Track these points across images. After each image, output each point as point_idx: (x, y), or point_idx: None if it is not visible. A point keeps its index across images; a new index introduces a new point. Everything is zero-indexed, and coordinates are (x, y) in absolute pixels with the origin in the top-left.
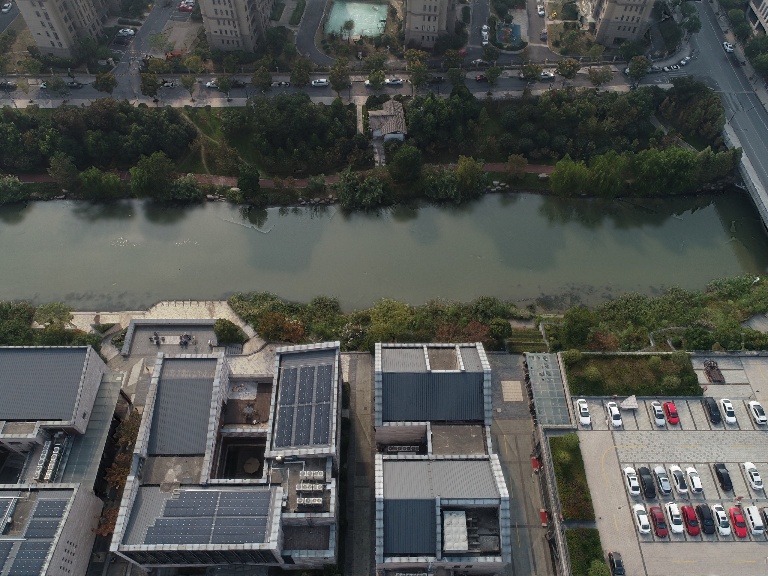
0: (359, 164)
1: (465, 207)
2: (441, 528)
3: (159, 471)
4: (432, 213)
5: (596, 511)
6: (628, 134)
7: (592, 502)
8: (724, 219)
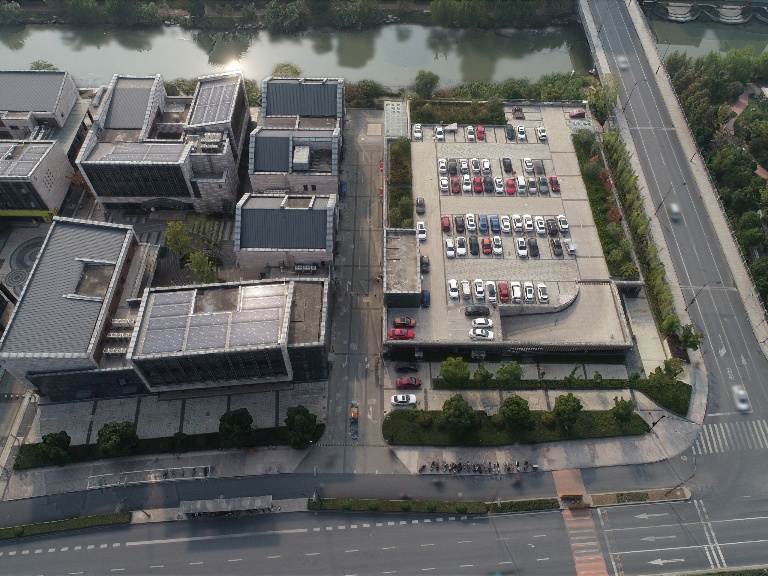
0: (284, 2)
1: (364, 32)
2: (292, 154)
3: (111, 136)
4: (338, 36)
5: (414, 180)
6: None
7: None
8: (570, 50)
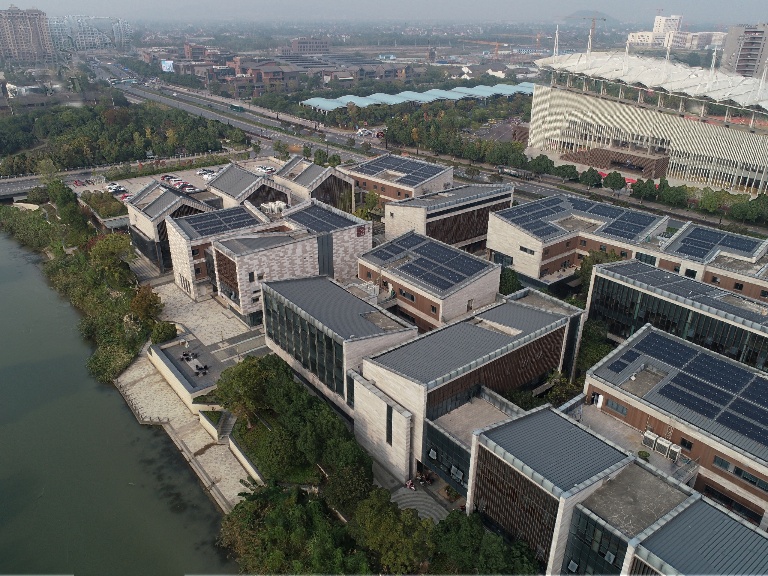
0: None
1: None
2: None
3: None
4: None
5: None
6: None
7: None
8: None
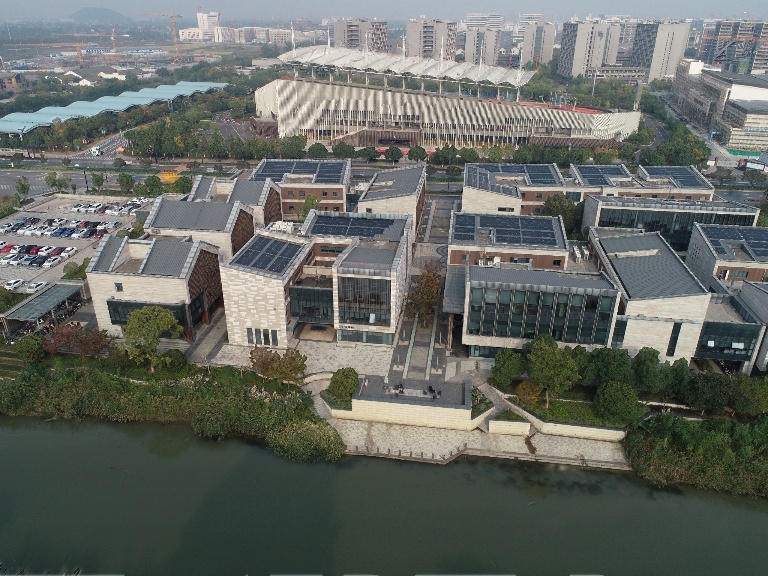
0: None
1: None
2: None
3: (391, 245)
4: None
5: None
6: None
7: None
8: None
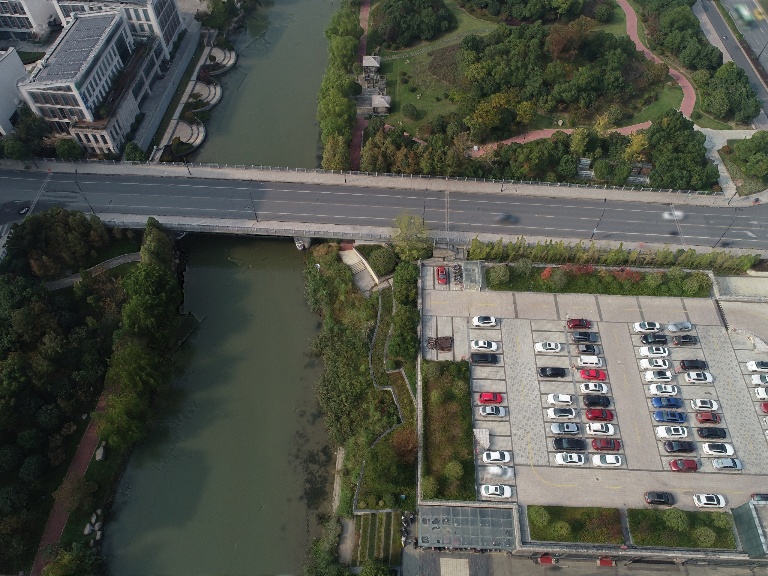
0: None
1: None
2: None
3: None
4: None
5: (605, 505)
6: (69, 324)
7: None
8: (209, 264)
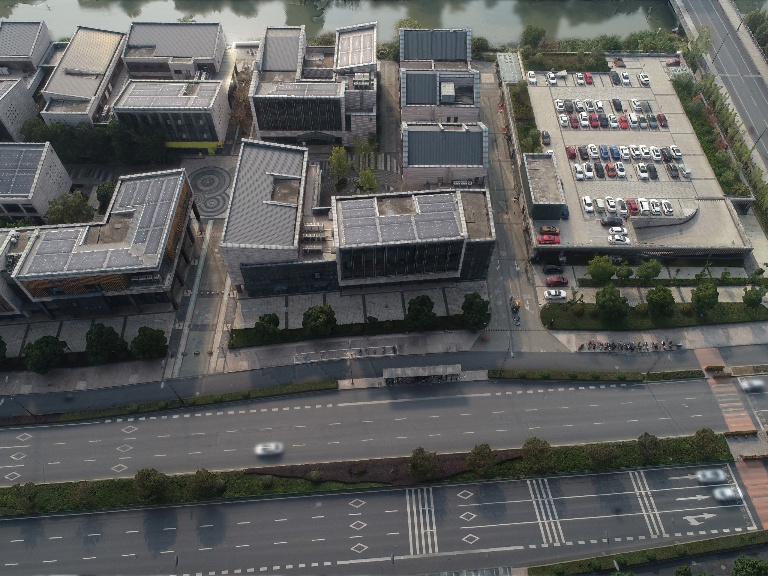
0: None
1: None
2: (439, 88)
3: (270, 77)
4: (436, 0)
5: (536, 118)
6: None
7: (534, 114)
8: None
